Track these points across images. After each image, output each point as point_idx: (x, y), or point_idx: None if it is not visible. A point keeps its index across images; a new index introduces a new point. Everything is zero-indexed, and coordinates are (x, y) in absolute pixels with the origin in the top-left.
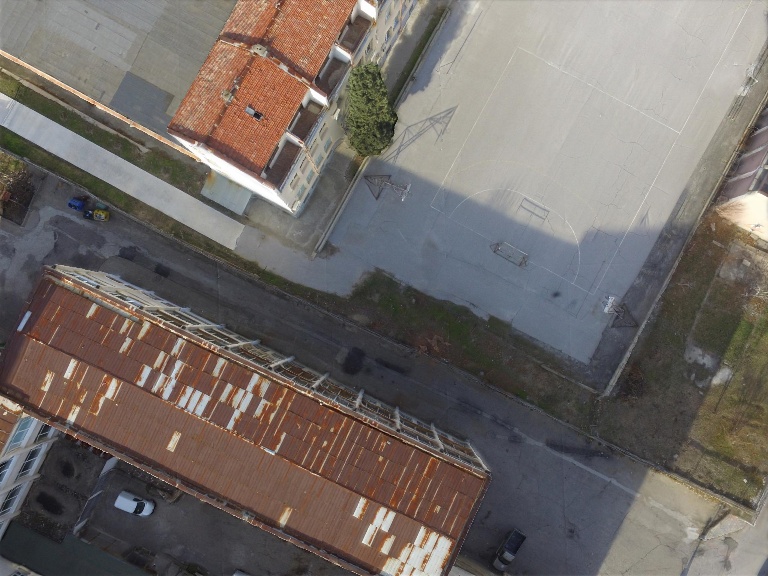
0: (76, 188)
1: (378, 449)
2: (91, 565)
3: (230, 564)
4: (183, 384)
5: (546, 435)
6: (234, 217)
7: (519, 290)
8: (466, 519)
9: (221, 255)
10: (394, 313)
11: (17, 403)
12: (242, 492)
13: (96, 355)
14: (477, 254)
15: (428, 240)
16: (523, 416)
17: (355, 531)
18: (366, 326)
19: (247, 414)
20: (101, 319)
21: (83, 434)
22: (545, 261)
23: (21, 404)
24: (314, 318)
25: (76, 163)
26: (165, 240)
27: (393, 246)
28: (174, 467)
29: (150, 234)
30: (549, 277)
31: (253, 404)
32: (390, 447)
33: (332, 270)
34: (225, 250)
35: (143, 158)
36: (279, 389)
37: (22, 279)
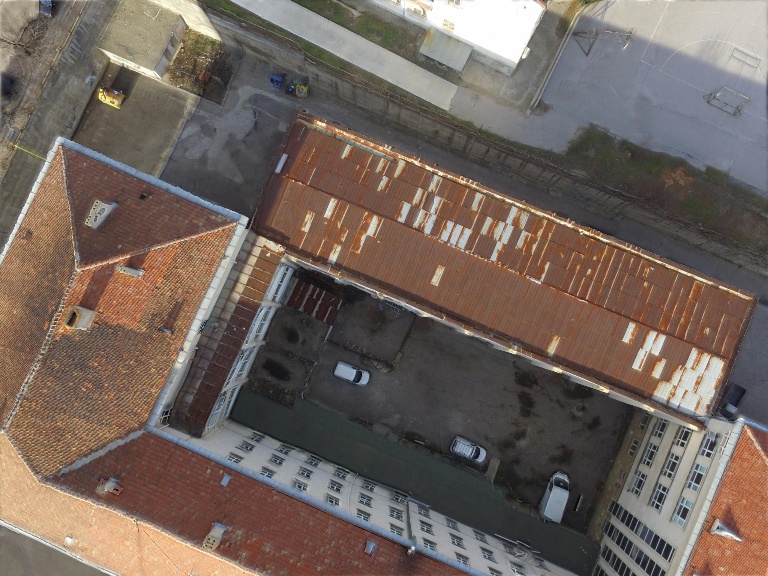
0: (274, 66)
1: (642, 275)
2: (323, 428)
3: (448, 431)
4: (444, 219)
5: (756, 291)
6: (447, 78)
7: (734, 139)
8: (736, 339)
9: (437, 116)
10: (611, 167)
11: (280, 244)
12: (508, 323)
13: (355, 194)
14: (690, 105)
15: (641, 94)
16: (732, 273)
17: (625, 356)
18: (586, 180)
19: (509, 245)
20: (356, 159)
21: (345, 273)
22: (759, 109)
23: (283, 245)
24: (517, 185)
25: (290, 29)
26: (365, 113)
27: (606, 101)
28: (438, 302)
29: (350, 108)
30: (764, 125)
31: (514, 236)
32: (654, 273)
33: (547, 127)
34: (440, 111)
35: (356, 22)
36: (538, 221)
37: (224, 158)
